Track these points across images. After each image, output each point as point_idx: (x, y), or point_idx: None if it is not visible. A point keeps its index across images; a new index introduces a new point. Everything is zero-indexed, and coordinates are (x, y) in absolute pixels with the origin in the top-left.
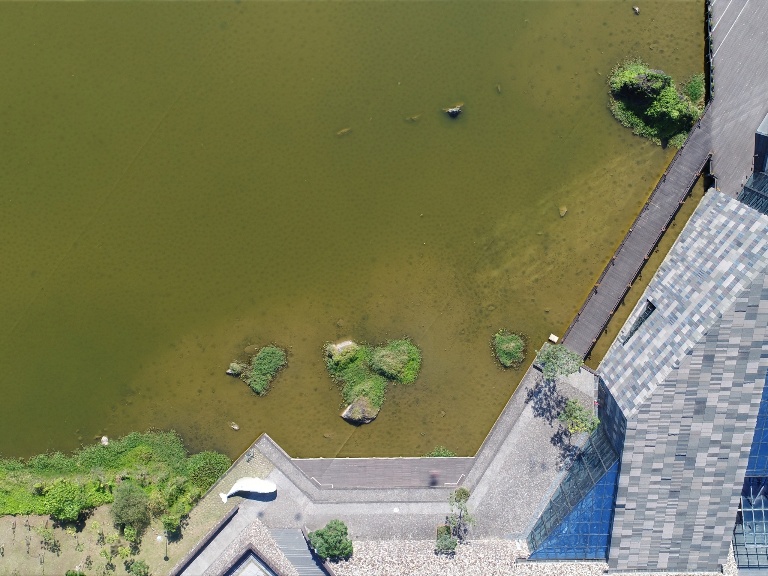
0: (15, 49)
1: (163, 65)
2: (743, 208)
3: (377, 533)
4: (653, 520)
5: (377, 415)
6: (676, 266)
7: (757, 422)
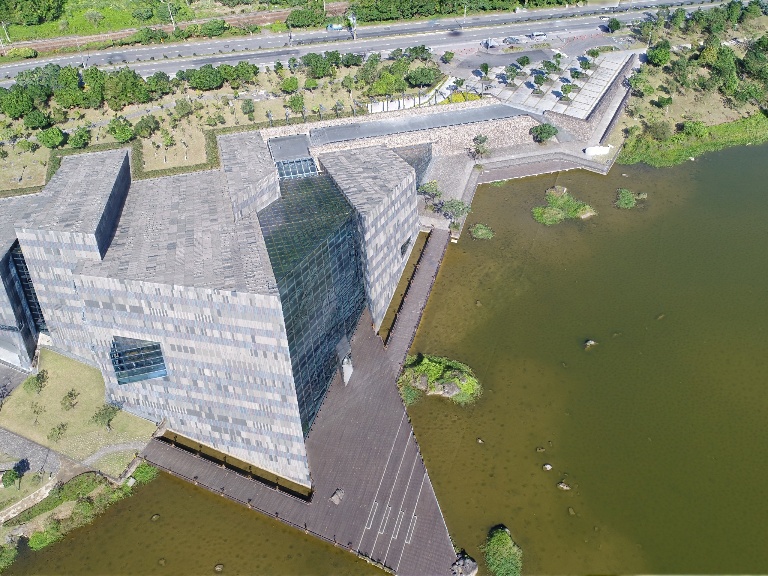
0: None
1: None
2: None
3: (518, 147)
4: None
5: None
6: None
7: None
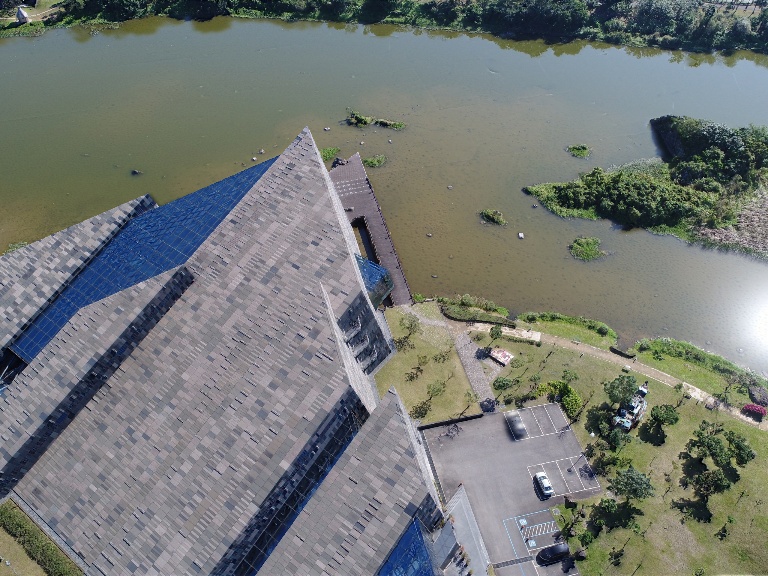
0: (24, 79)
1: (60, 105)
2: None
3: None
4: None
5: None
6: None
7: None
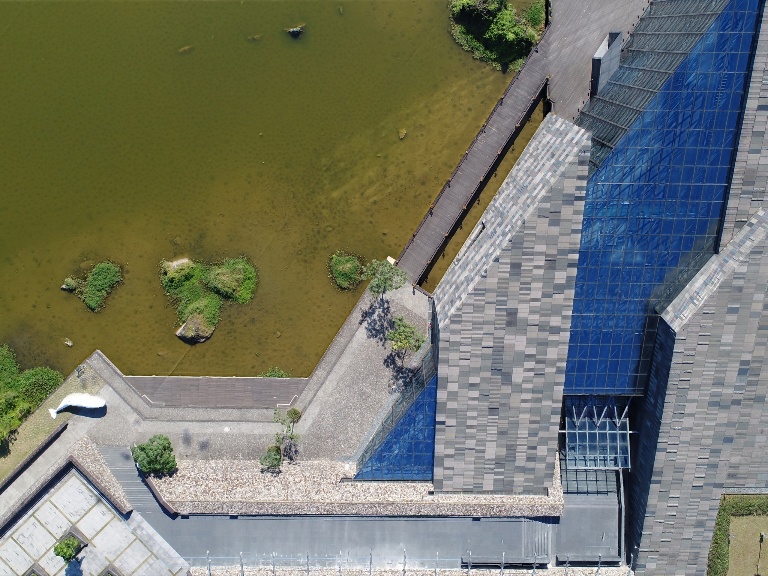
0: None
1: None
2: (564, 124)
3: (207, 452)
4: (475, 439)
5: (212, 334)
6: (508, 187)
7: (572, 337)
